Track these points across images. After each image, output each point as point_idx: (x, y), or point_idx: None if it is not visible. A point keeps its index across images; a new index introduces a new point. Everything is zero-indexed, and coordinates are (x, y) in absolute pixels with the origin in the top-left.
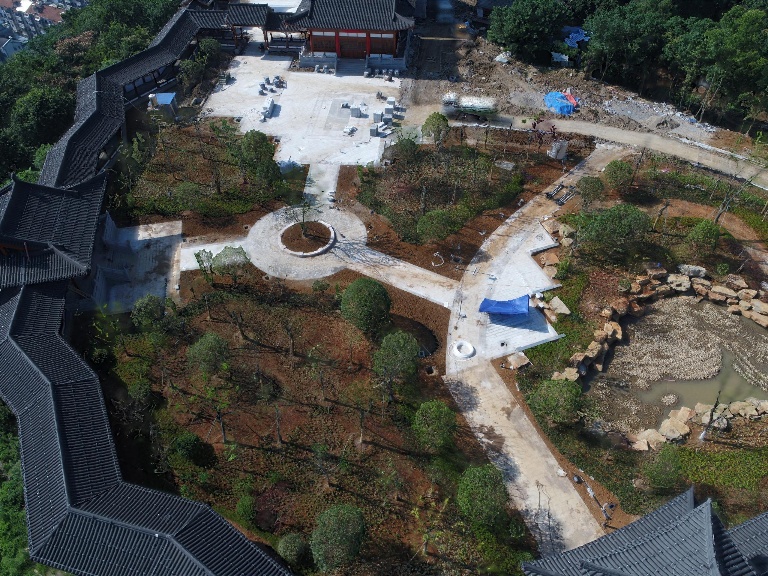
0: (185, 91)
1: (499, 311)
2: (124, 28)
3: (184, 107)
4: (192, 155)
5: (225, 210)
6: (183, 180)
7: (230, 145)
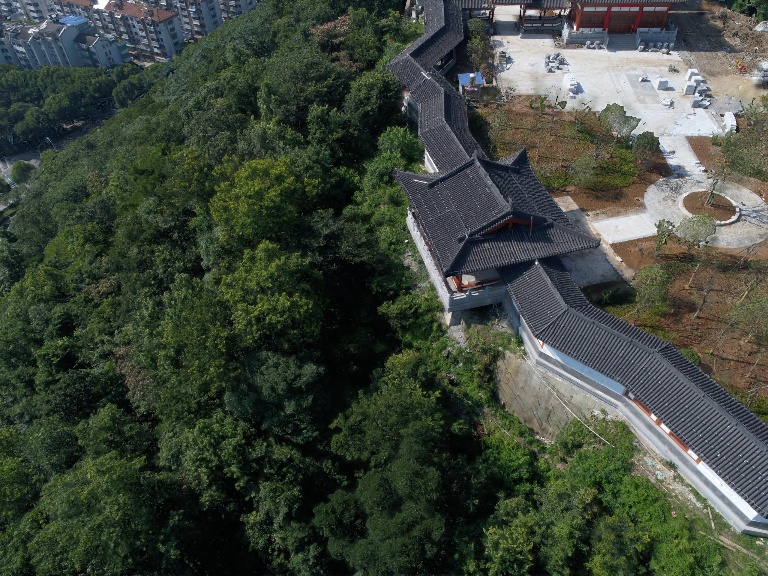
0: (469, 72)
1: None
2: (366, 12)
3: (485, 87)
4: (533, 132)
5: (610, 184)
6: (546, 157)
7: (579, 120)
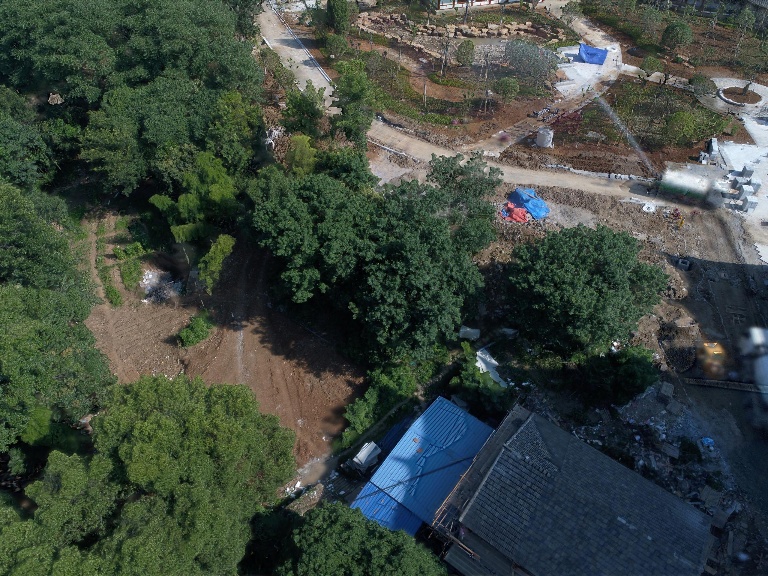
0: None
1: (597, 49)
2: None
3: None
4: None
5: None
6: None
7: None
